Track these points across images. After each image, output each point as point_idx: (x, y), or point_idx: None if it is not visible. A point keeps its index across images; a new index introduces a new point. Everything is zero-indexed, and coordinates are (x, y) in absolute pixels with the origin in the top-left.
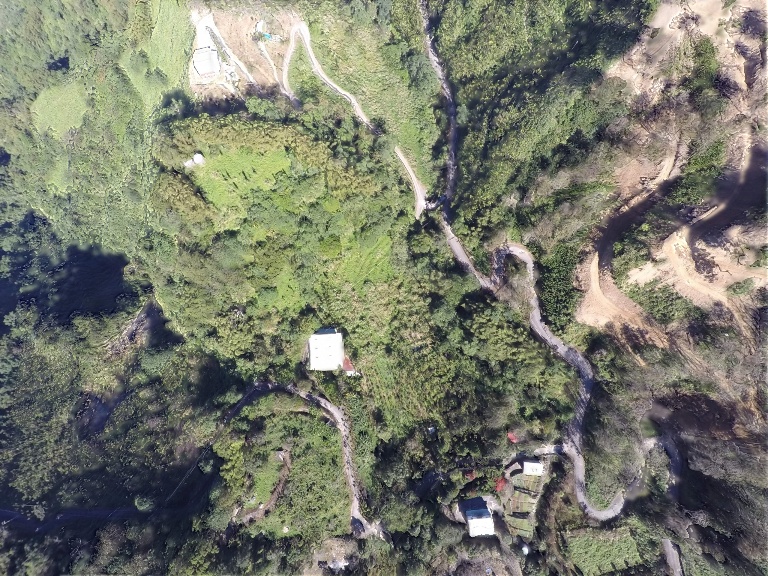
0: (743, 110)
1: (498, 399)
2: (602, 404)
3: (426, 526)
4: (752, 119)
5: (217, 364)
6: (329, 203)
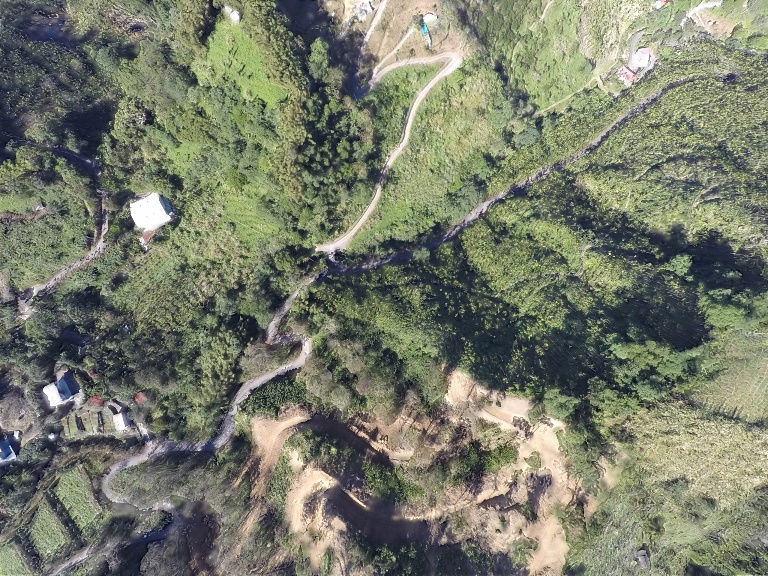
0: (456, 505)
1: (170, 375)
2: (189, 462)
3: (37, 350)
4: (448, 515)
5: (112, 119)
6: (263, 160)
